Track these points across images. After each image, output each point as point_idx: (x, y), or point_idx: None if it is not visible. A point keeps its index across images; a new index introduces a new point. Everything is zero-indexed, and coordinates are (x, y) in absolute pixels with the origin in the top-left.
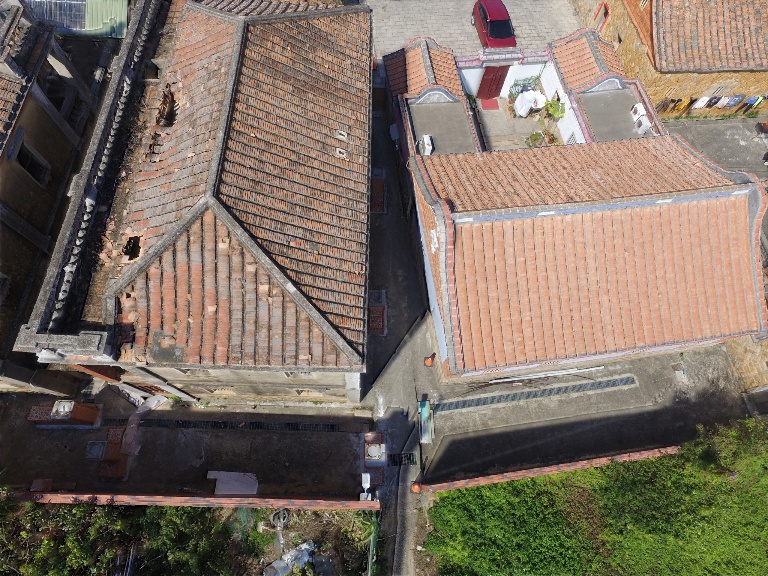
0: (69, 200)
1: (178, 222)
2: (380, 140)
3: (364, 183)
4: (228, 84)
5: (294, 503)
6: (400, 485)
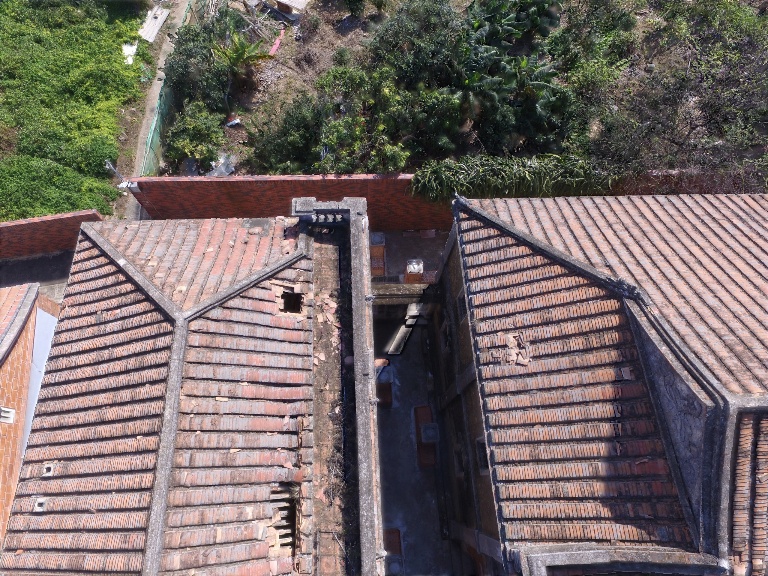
0: (467, 456)
1: (220, 297)
2: None
3: (34, 434)
4: (159, 514)
5: (188, 179)
6: None
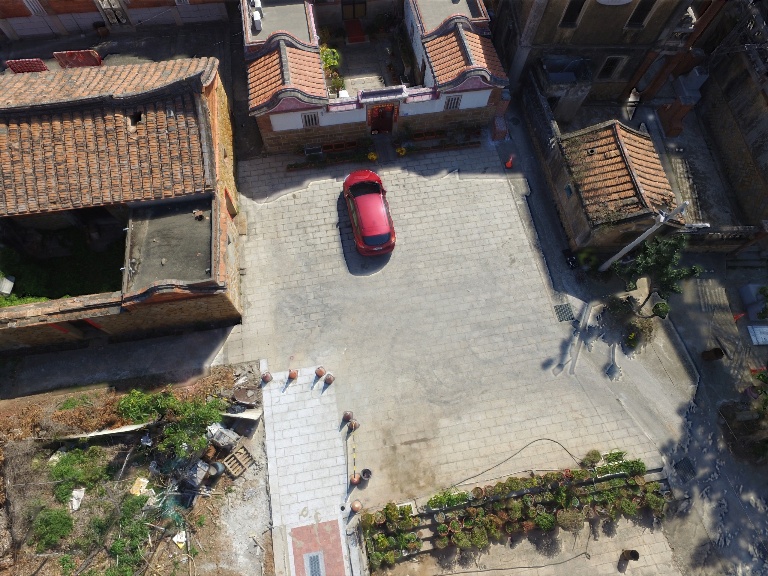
0: None
1: None
2: None
3: None
4: None
5: None
6: None
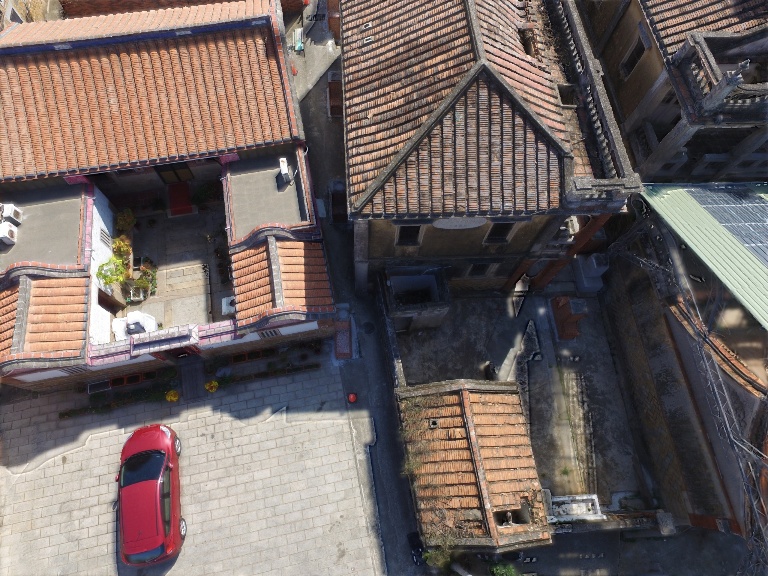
0: None
1: None
2: (339, 275)
3: None
4: None
5: None
6: (317, 4)
